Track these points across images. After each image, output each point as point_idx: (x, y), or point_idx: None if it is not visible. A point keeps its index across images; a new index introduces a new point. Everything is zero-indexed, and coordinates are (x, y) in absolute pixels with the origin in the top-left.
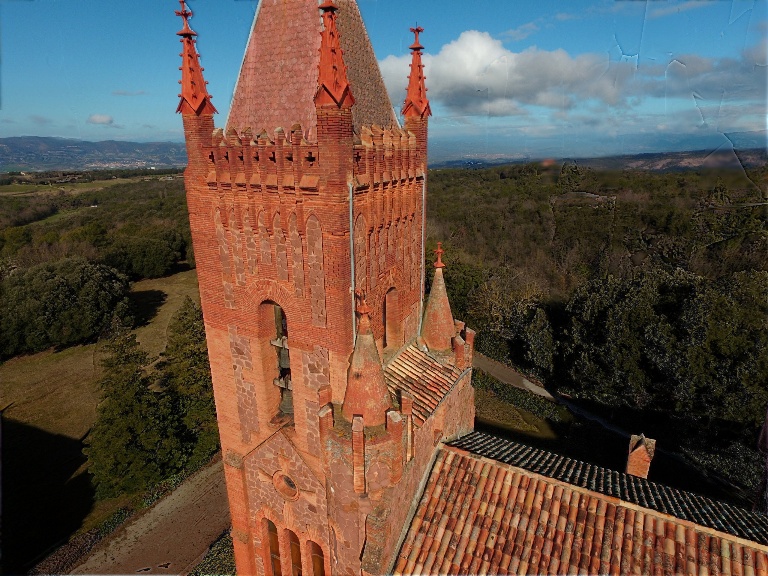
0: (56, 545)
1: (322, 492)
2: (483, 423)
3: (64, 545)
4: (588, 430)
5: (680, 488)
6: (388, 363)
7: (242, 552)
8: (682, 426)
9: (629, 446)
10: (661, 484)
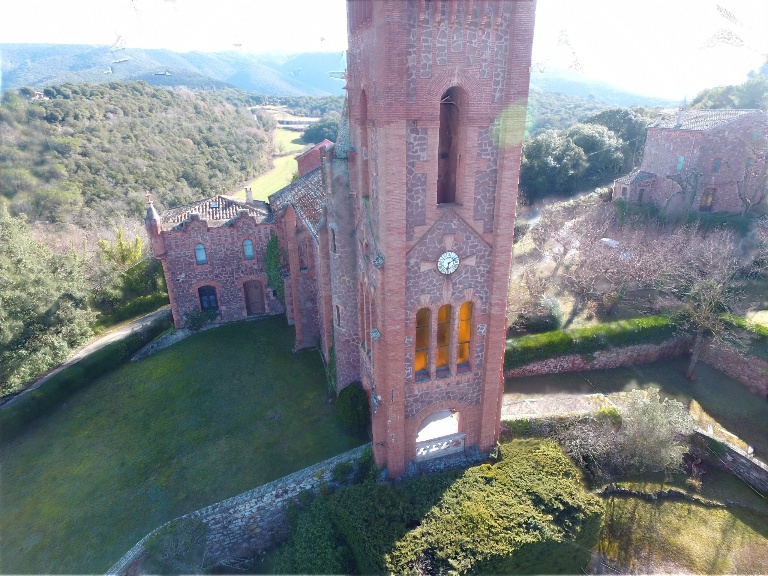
0: None
1: None
2: None
3: None
4: None
5: None
6: None
7: None
8: None
9: (288, 213)
10: (74, 395)
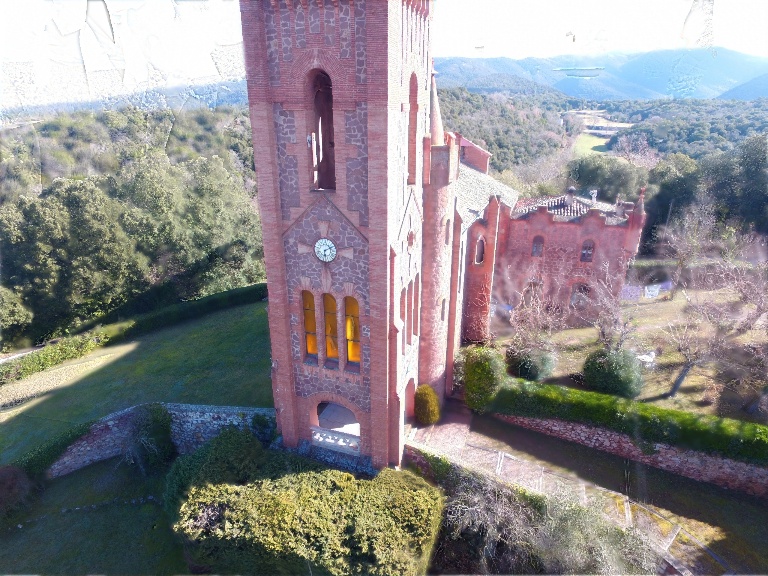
0: None
1: (420, 225)
2: (67, 387)
3: None
4: (144, 322)
5: (228, 304)
6: None
7: (400, 341)
8: (173, 285)
9: None
10: (217, 311)
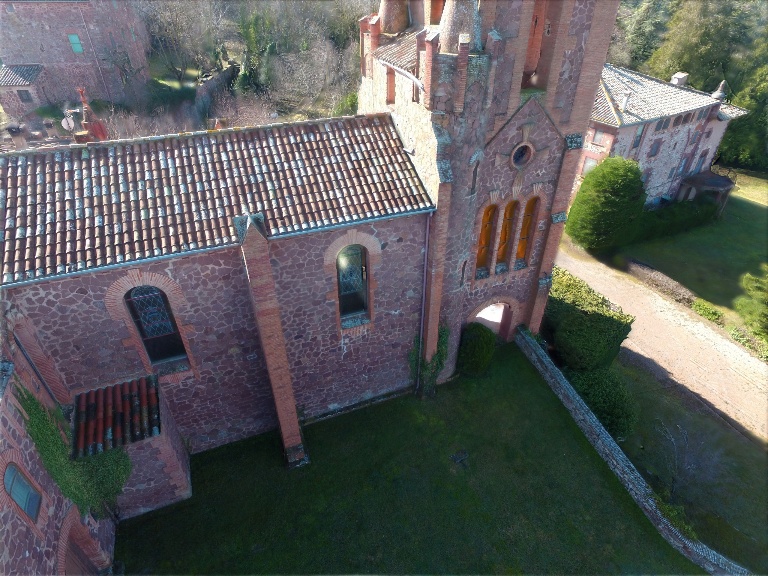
0: (693, 292)
1: None
2: None
3: (679, 283)
4: None
5: None
6: (433, 30)
7: None
8: None
9: None
10: None
